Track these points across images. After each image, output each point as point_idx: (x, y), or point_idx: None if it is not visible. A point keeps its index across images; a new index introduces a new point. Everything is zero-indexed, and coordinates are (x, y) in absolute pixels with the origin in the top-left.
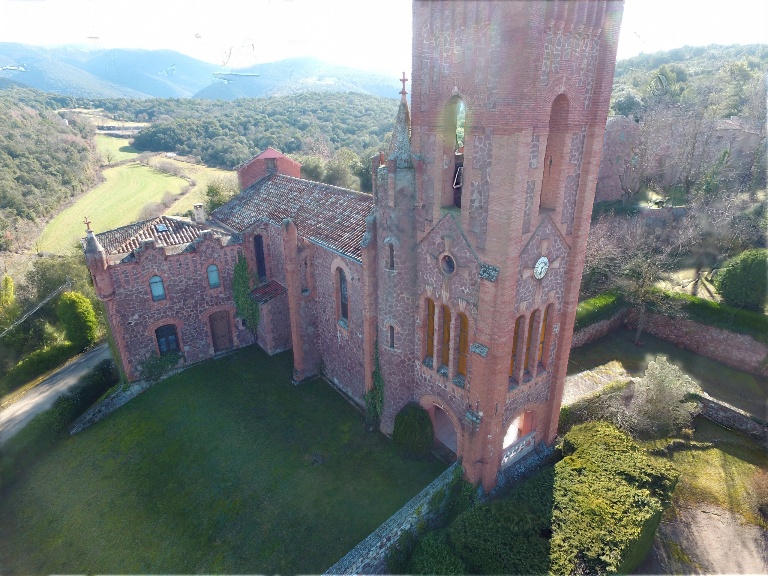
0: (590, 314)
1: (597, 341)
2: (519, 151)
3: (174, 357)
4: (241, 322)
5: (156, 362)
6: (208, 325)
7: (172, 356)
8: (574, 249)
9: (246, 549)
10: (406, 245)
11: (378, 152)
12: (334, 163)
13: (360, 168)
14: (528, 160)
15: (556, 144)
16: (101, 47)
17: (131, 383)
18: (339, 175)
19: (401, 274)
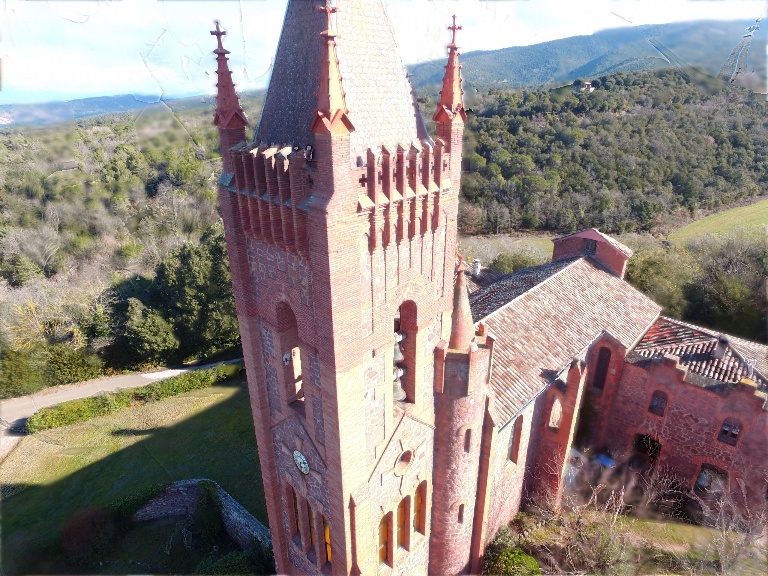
0: None
1: None
2: (241, 330)
3: None
4: None
5: None
6: None
7: None
8: None
9: None
10: None
11: None
12: None
13: None
14: (250, 343)
15: None
16: None
17: None
18: None
19: None
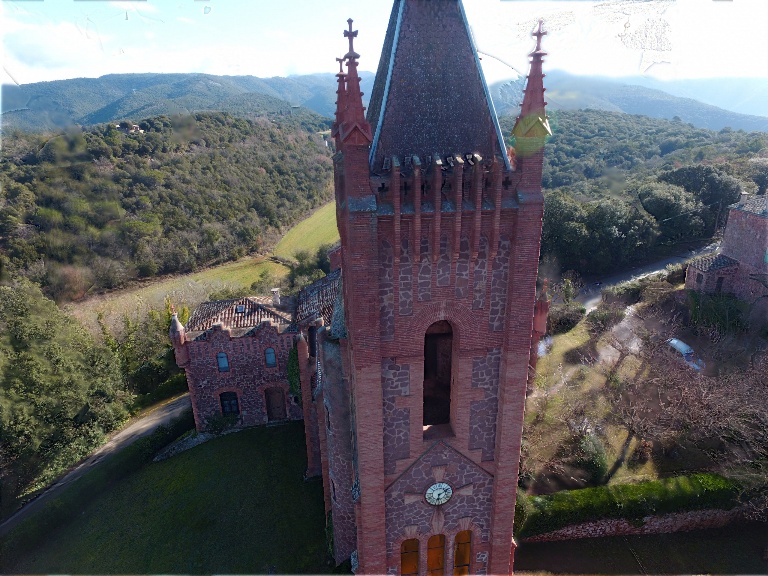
0: (686, 498)
1: (702, 533)
2: (361, 387)
3: (233, 418)
4: (293, 399)
5: (219, 420)
6: (264, 397)
7: (232, 417)
8: (496, 479)
9: None
10: (338, 412)
11: None
12: None
13: None
14: (379, 395)
15: (455, 364)
16: (301, 115)
17: (198, 432)
18: None
19: (335, 437)
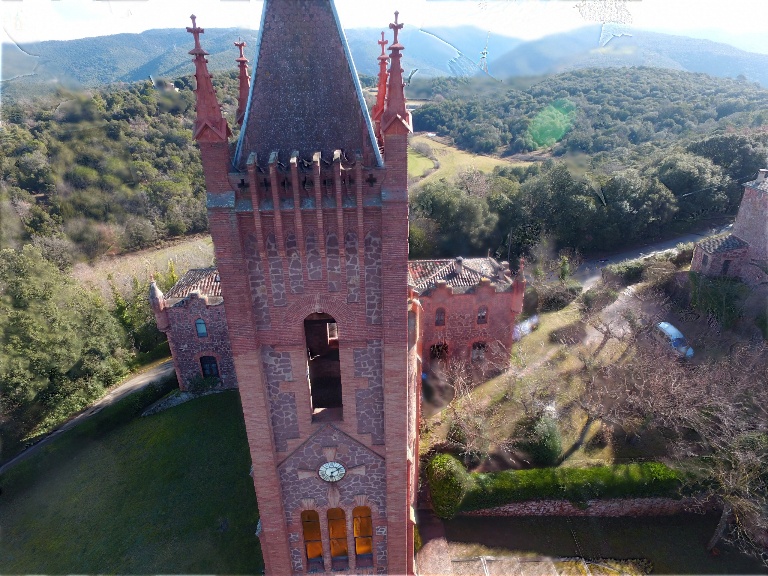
0: (633, 485)
1: (649, 520)
2: (240, 372)
3: (213, 381)
4: None
5: (200, 381)
6: None
7: (212, 380)
8: None
9: (131, 575)
10: None
11: (536, 186)
12: (468, 200)
13: (507, 203)
14: (259, 380)
15: None
16: None
17: (182, 392)
18: (469, 214)
19: None
